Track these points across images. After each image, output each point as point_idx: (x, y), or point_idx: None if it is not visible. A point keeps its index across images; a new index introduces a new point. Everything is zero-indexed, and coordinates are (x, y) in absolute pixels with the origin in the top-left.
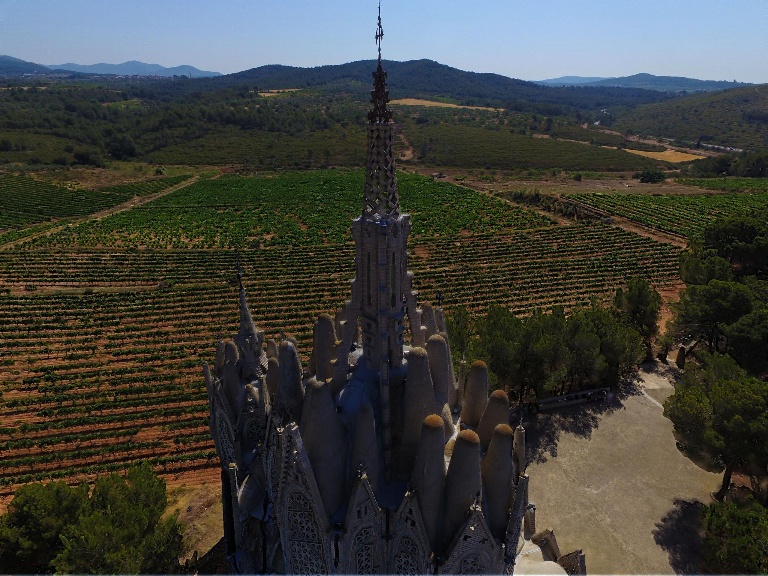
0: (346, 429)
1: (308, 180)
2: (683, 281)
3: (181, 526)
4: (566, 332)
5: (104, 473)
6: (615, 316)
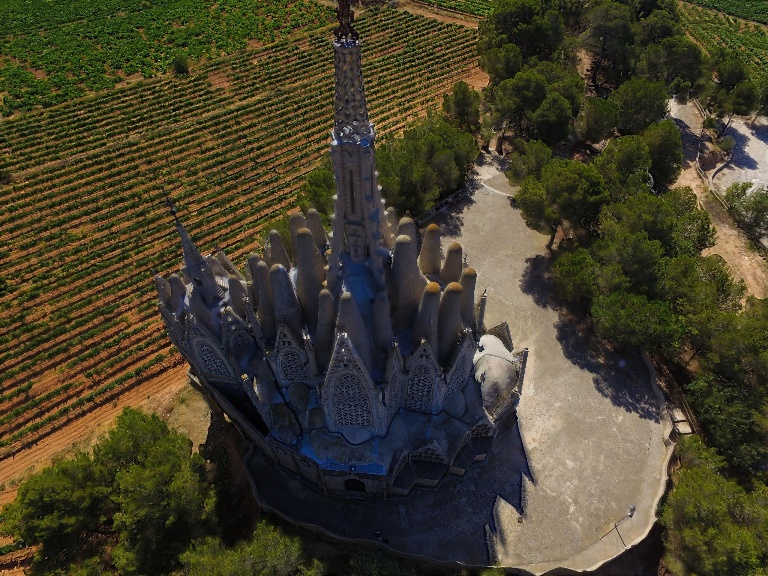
0: (364, 317)
1: None
2: None
3: (179, 438)
4: (424, 153)
5: (28, 436)
6: (446, 121)
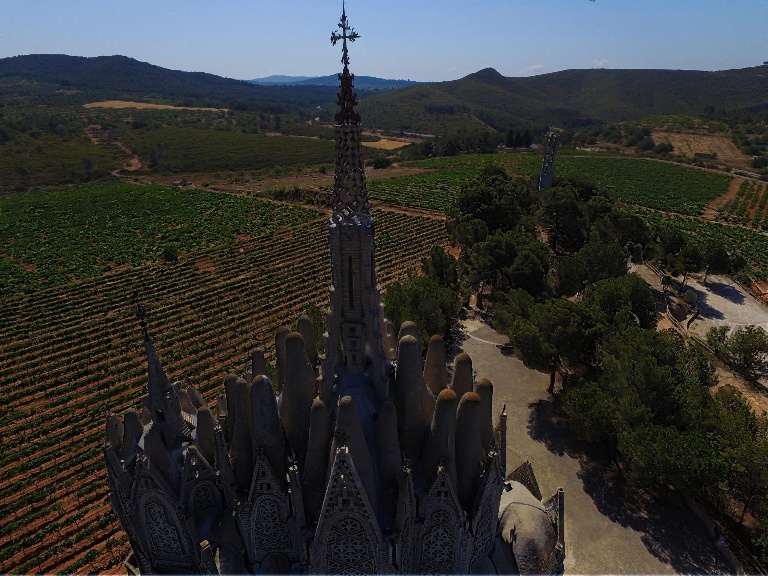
0: (365, 437)
1: (5, 208)
2: (458, 243)
3: None
4: (409, 303)
5: None
6: None
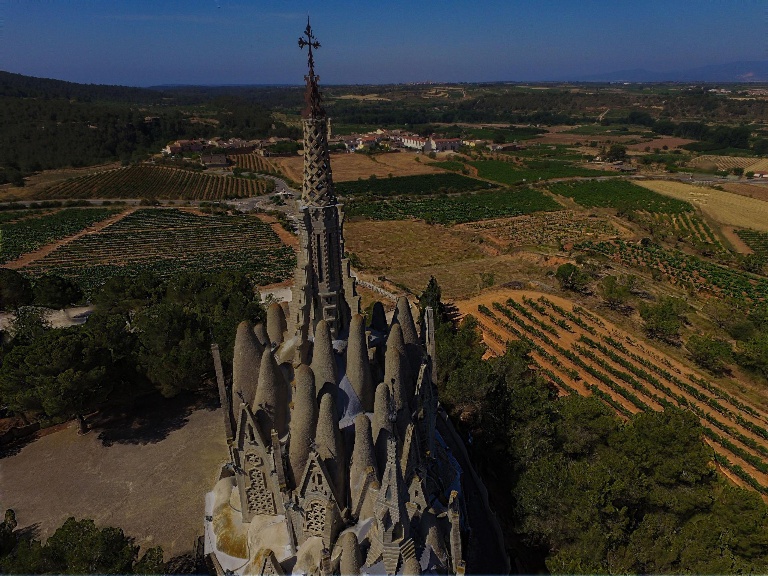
0: None
1: None
2: None
3: None
4: None
5: None
6: None
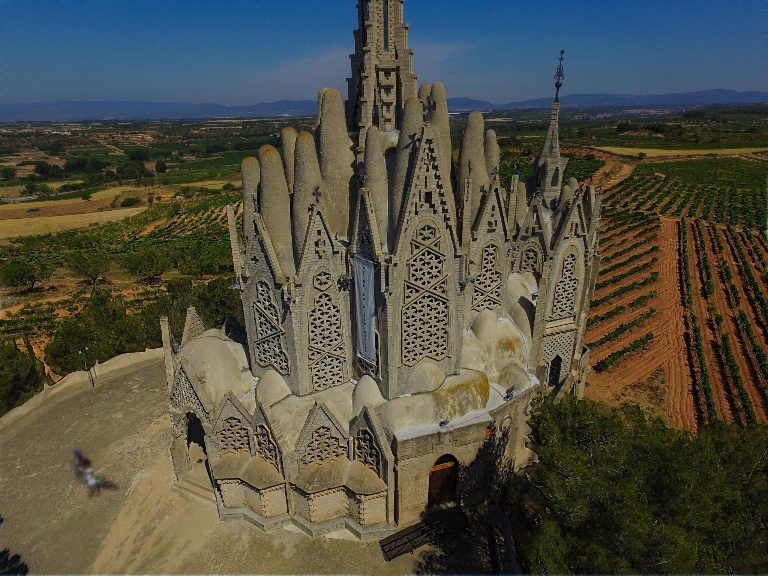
0: None
1: None
2: None
3: None
4: None
5: None
6: None
